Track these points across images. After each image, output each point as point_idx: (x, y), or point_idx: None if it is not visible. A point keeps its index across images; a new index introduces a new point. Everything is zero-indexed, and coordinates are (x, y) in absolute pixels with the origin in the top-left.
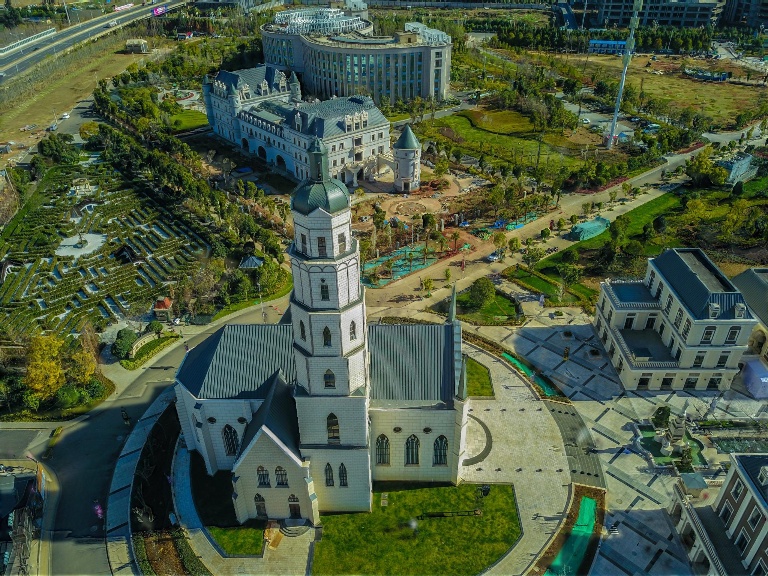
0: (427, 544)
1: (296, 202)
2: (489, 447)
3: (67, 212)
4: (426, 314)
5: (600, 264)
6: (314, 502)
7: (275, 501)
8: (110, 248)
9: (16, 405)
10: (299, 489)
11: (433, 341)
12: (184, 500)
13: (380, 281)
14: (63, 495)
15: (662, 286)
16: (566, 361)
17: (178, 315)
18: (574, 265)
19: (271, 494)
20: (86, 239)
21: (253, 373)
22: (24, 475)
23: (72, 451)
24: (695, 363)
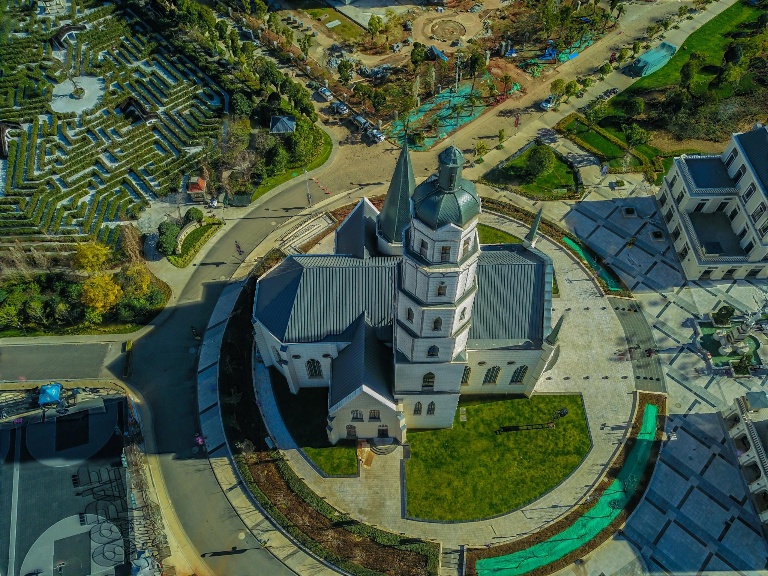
0: (507, 459)
1: (421, 212)
2: (557, 353)
3: (46, 44)
4: (479, 186)
5: (664, 113)
6: (404, 431)
7: (366, 429)
8: (113, 99)
9: (78, 319)
10: (390, 422)
11: (523, 280)
12: (274, 420)
13: (425, 141)
14: (155, 416)
15: (745, 170)
16: None
17: (214, 195)
18: None
19: (363, 425)
20: (81, 85)
21: (337, 317)
22: (111, 397)
23: (149, 367)
24: (764, 257)
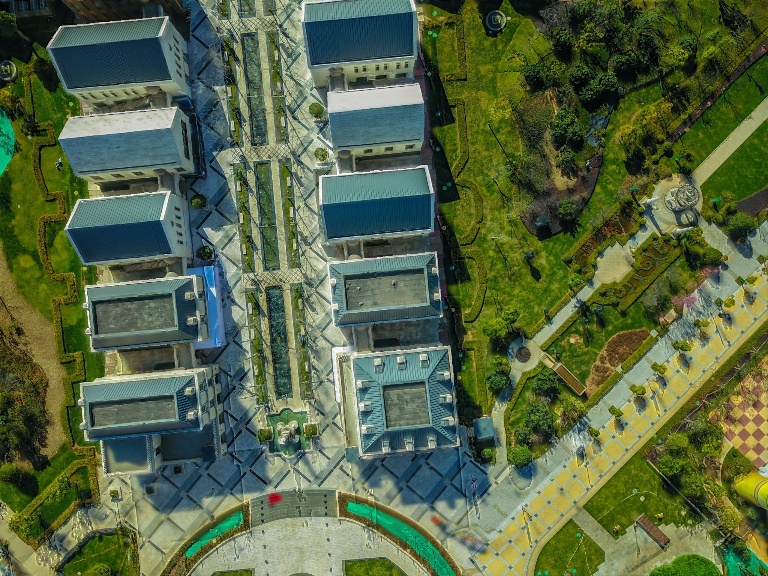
0: None
1: None
2: None
3: None
4: None
5: None
6: None
7: None
8: None
9: None
10: None
11: None
12: None
13: None
14: None
15: None
16: (190, 496)
17: None
18: (9, 461)
19: None
20: None
21: None
22: None
23: None
24: None
